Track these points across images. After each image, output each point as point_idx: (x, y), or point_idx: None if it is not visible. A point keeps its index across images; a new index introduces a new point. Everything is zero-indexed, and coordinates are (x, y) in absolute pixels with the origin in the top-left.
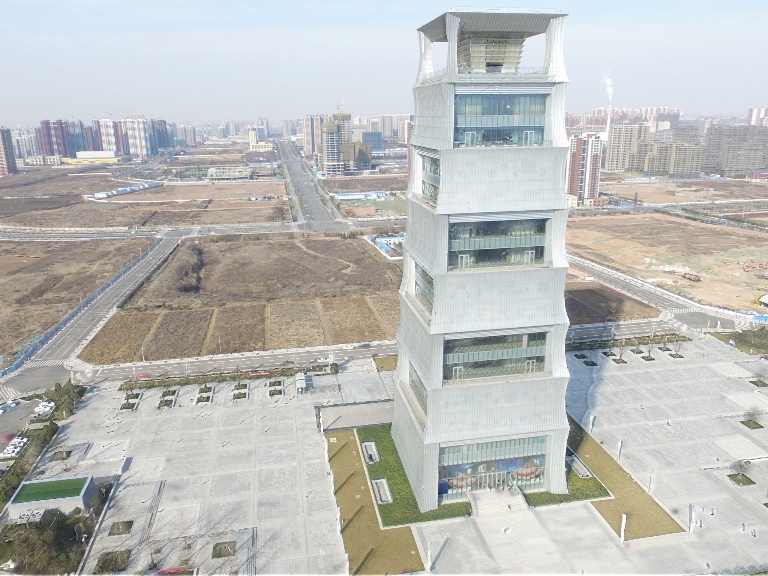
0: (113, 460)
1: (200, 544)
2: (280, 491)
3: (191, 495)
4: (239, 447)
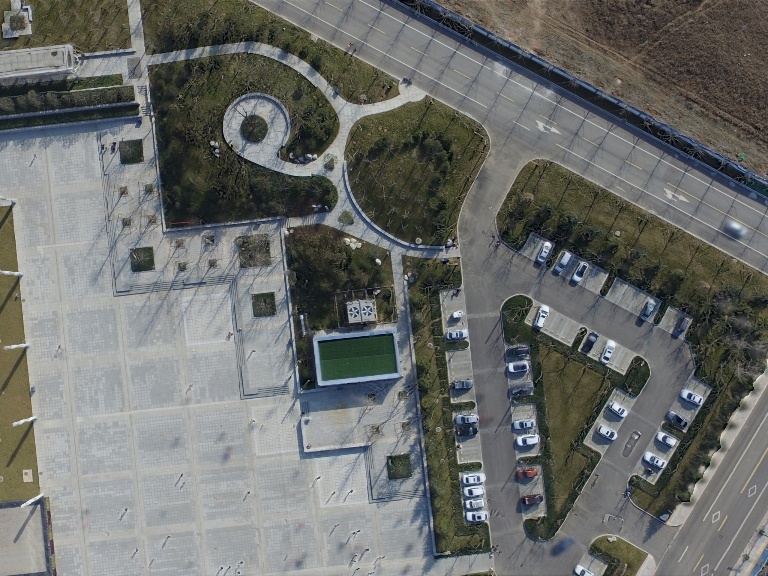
0: (322, 448)
1: (171, 271)
2: (94, 361)
3: (202, 363)
4: (160, 469)
